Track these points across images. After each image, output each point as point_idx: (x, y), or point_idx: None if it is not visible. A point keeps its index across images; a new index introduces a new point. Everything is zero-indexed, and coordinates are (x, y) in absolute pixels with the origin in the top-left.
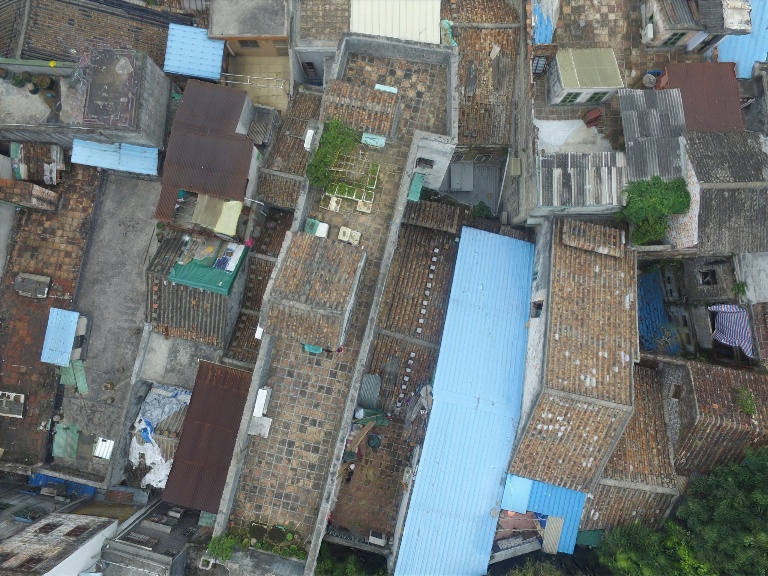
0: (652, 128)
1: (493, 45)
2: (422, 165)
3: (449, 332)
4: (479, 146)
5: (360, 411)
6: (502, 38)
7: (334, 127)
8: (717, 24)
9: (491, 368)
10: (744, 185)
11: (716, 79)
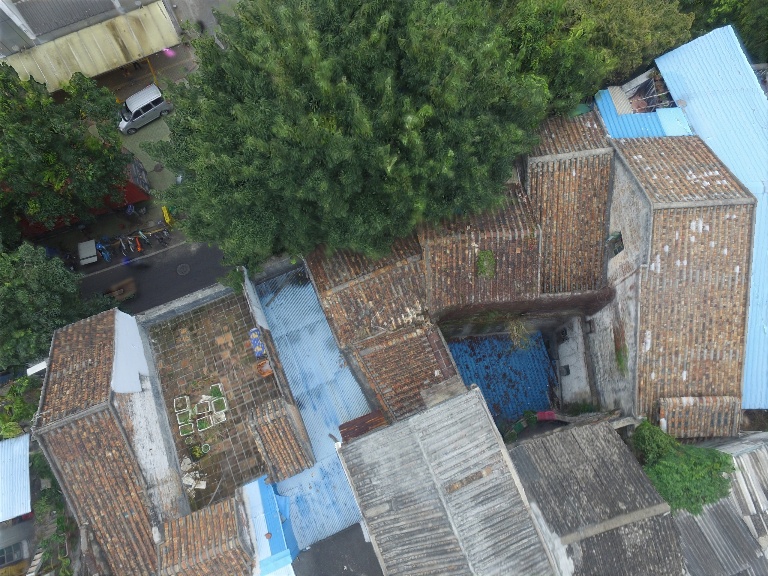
0: None
1: None
2: None
3: None
4: None
5: None
6: None
7: None
8: None
9: None
10: (608, 525)
11: None
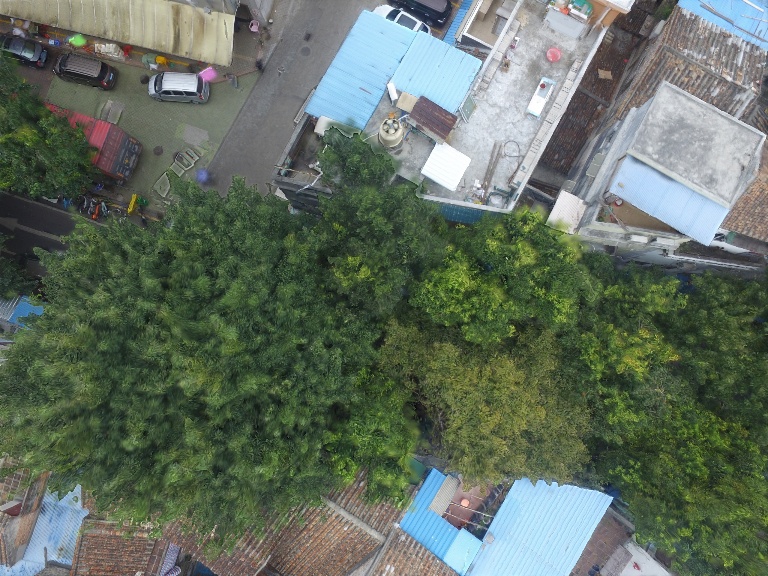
0: None
1: None
2: None
3: None
4: None
5: None
6: None
7: None
8: None
9: None
10: None
11: None
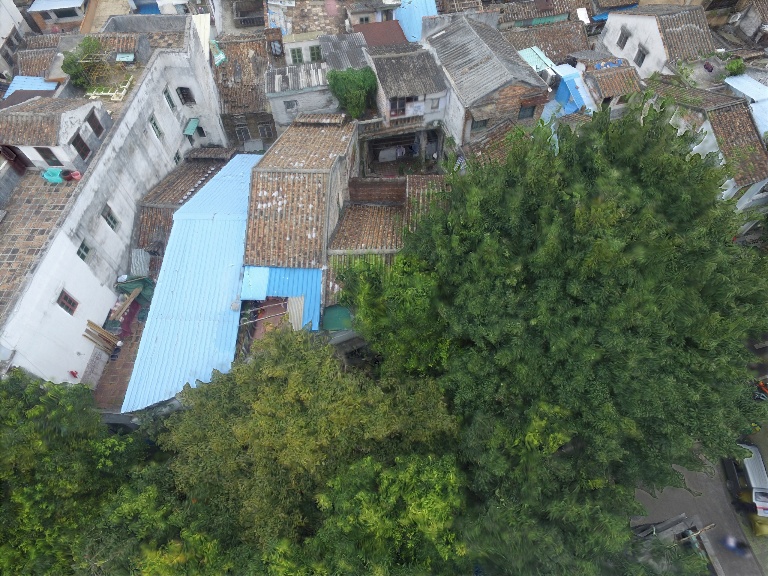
0: (343, 48)
1: (249, 50)
2: (188, 103)
3: (203, 191)
4: (252, 113)
5: (123, 275)
6: (255, 46)
7: (85, 39)
8: (379, 3)
9: (235, 202)
10: (403, 54)
11: (386, 27)
